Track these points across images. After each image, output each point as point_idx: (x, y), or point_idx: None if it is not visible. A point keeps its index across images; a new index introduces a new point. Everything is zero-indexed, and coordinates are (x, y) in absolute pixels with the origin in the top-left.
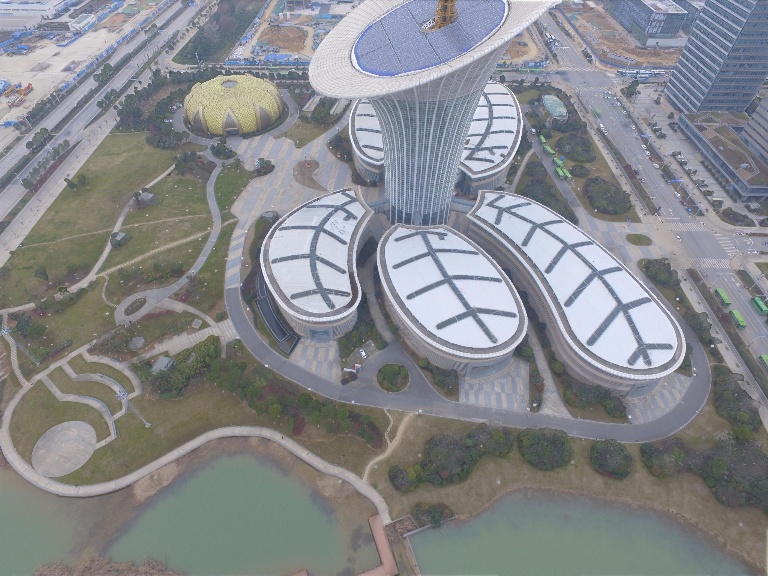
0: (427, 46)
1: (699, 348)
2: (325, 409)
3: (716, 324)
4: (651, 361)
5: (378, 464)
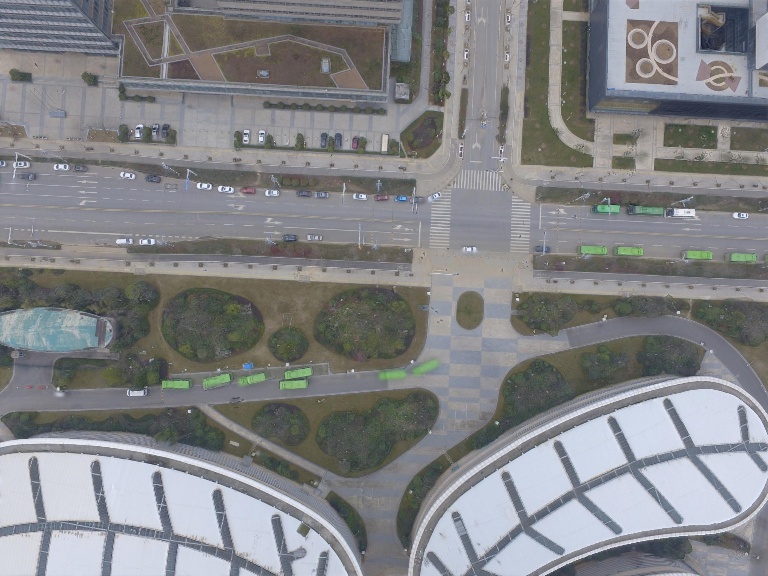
0: None
1: (666, 320)
2: None
3: (631, 280)
4: (763, 443)
5: None
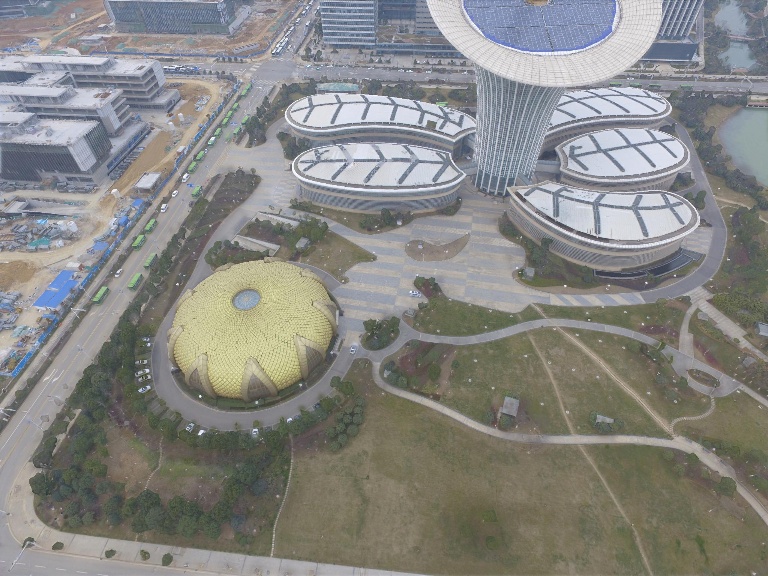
0: (578, 6)
1: None
2: (756, 221)
3: None
4: None
5: (759, 214)
